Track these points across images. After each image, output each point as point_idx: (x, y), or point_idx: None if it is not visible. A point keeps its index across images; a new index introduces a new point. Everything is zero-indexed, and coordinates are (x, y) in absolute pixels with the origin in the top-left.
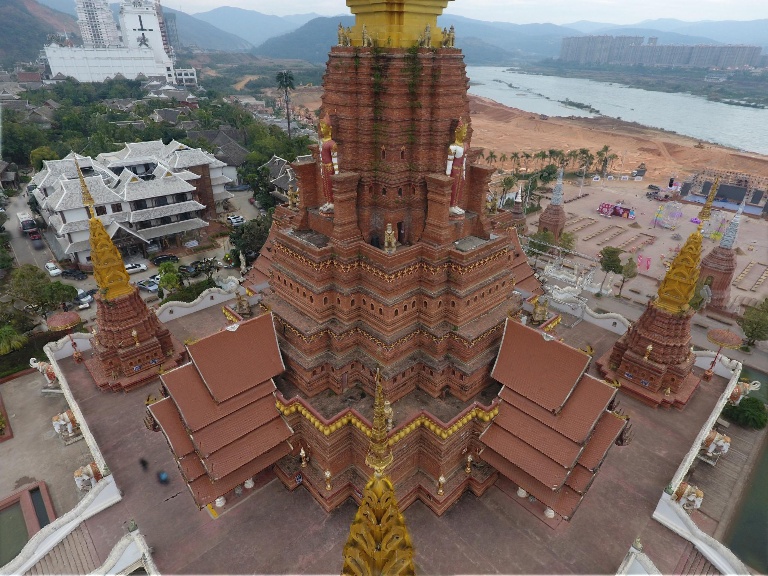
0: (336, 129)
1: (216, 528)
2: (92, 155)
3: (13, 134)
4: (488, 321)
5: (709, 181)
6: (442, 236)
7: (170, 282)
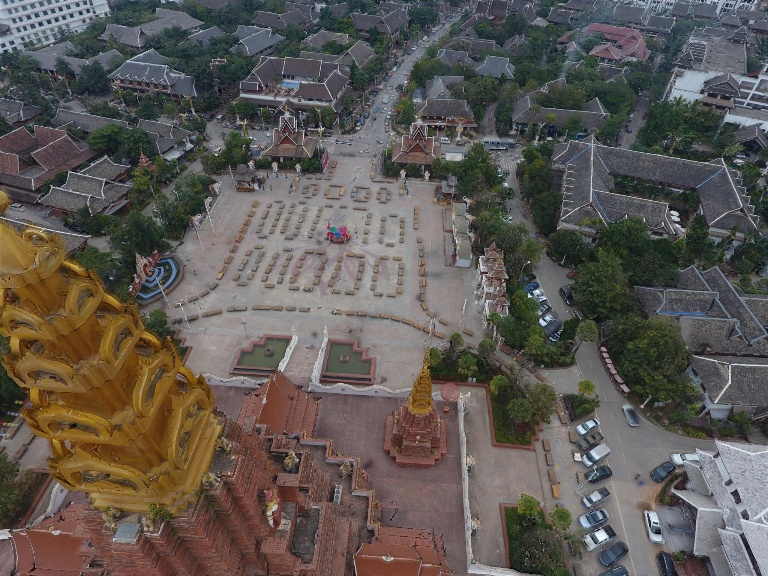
0: None
1: None
2: None
3: None
4: None
5: None
6: None
7: None
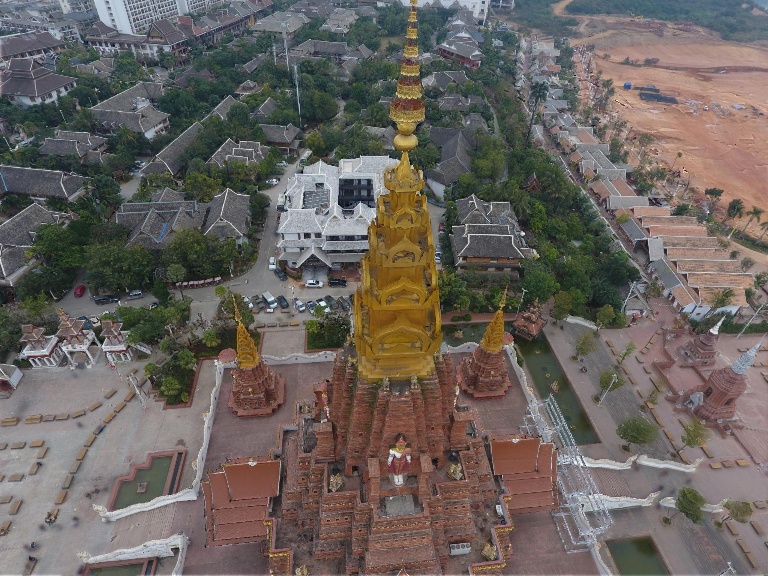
0: (331, 393)
1: (220, 552)
2: (343, 150)
3: (312, 101)
4: (395, 557)
5: None
6: (371, 496)
7: (312, 327)
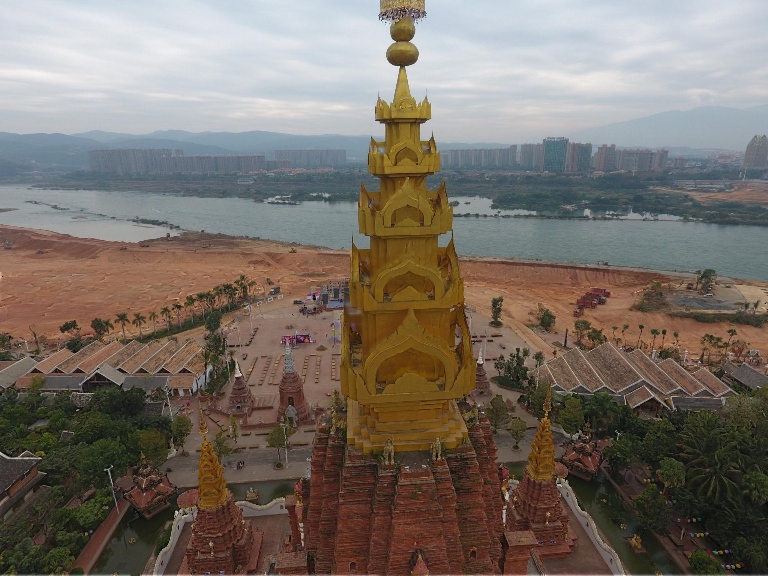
0: None
1: None
2: None
3: None
4: None
5: (336, 288)
6: None
7: None
